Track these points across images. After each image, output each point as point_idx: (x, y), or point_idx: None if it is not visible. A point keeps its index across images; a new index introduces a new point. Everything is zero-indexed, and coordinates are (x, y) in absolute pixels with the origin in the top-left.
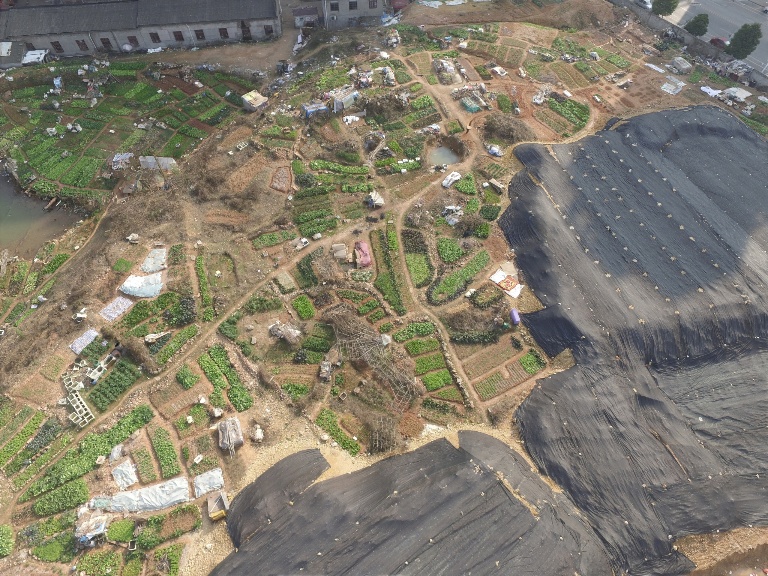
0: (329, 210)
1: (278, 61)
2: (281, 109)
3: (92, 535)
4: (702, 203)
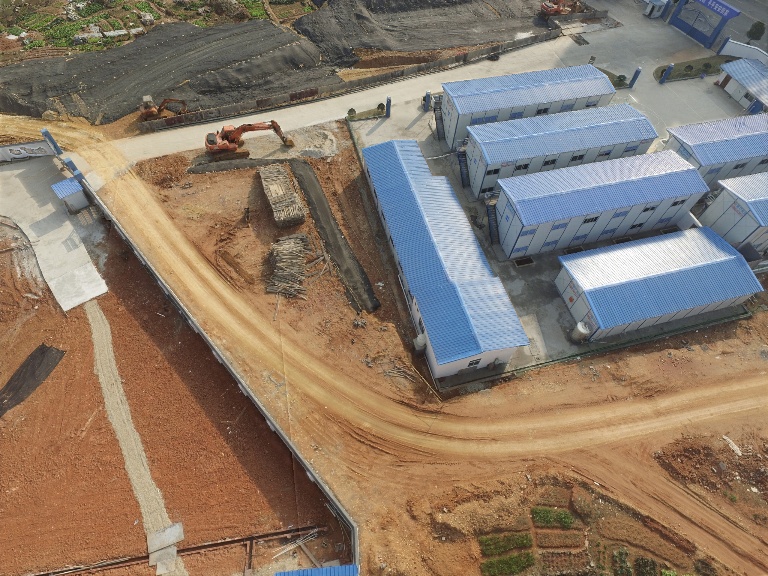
0: None
1: None
2: None
3: (81, 37)
4: None
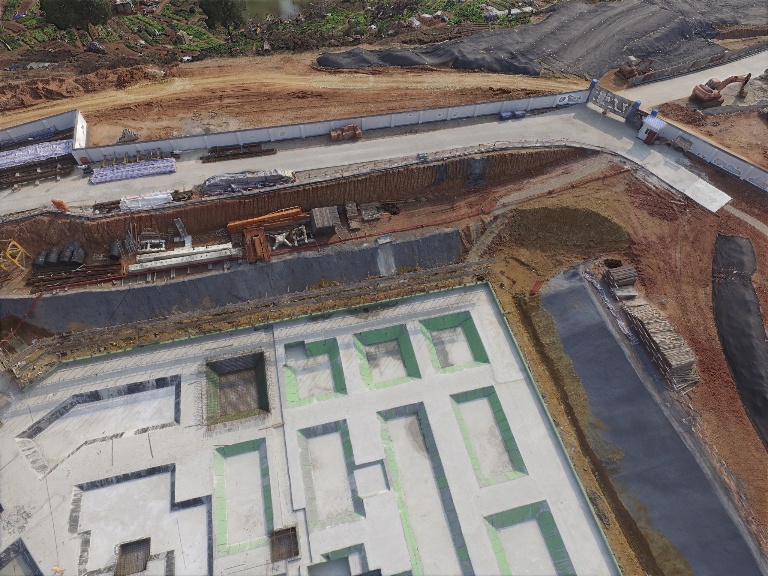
0: None
1: None
2: None
3: (495, 14)
4: None
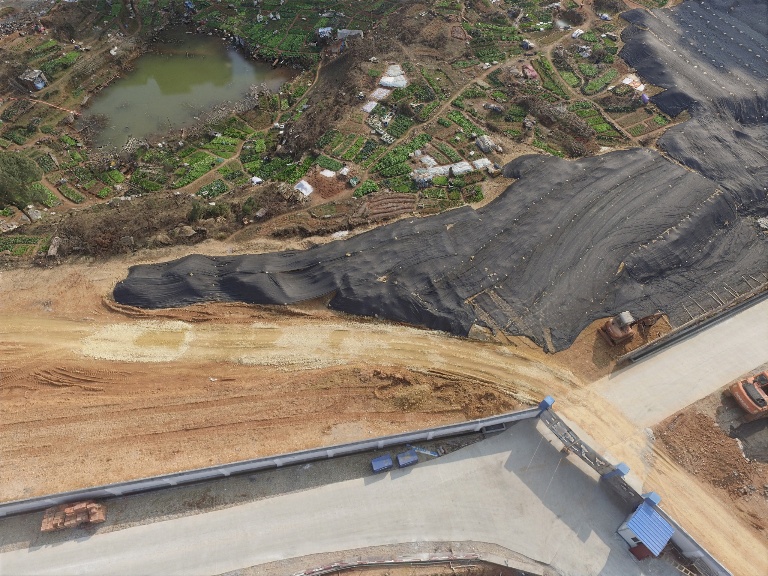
0: (497, 49)
1: None
2: None
3: (427, 179)
4: (761, 39)
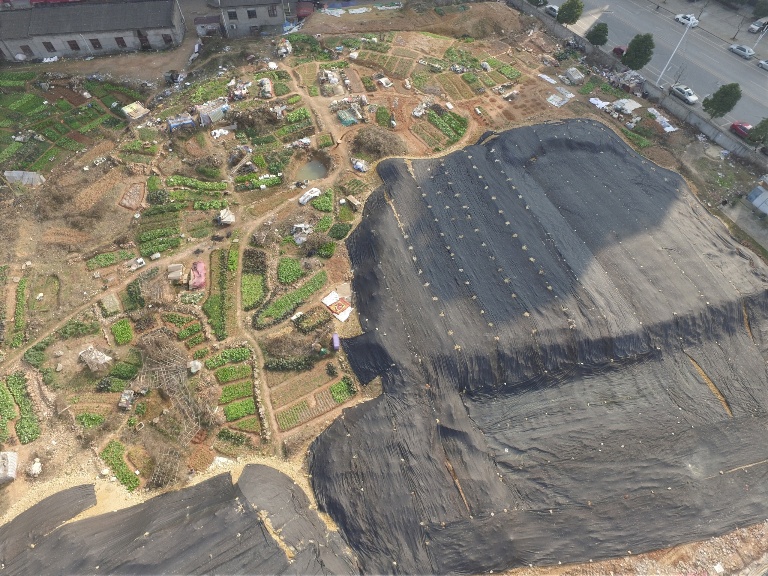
0: (175, 228)
1: (169, 71)
2: (148, 123)
3: None
4: (553, 221)
